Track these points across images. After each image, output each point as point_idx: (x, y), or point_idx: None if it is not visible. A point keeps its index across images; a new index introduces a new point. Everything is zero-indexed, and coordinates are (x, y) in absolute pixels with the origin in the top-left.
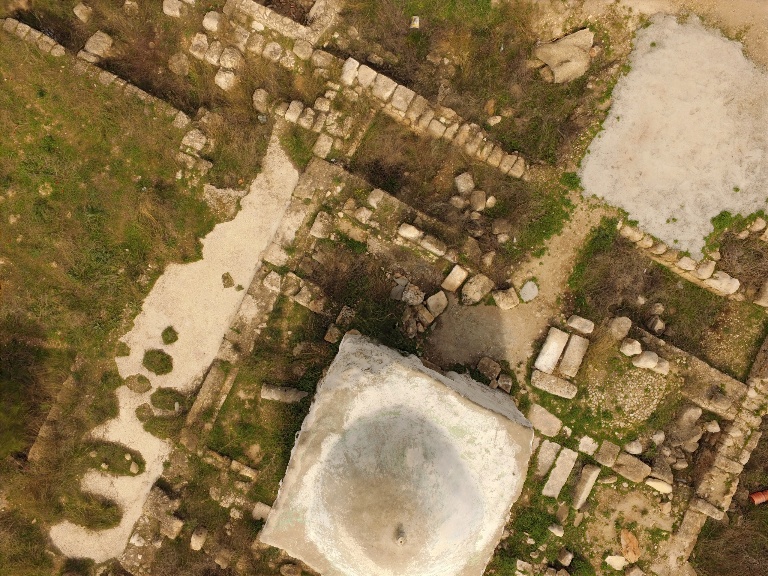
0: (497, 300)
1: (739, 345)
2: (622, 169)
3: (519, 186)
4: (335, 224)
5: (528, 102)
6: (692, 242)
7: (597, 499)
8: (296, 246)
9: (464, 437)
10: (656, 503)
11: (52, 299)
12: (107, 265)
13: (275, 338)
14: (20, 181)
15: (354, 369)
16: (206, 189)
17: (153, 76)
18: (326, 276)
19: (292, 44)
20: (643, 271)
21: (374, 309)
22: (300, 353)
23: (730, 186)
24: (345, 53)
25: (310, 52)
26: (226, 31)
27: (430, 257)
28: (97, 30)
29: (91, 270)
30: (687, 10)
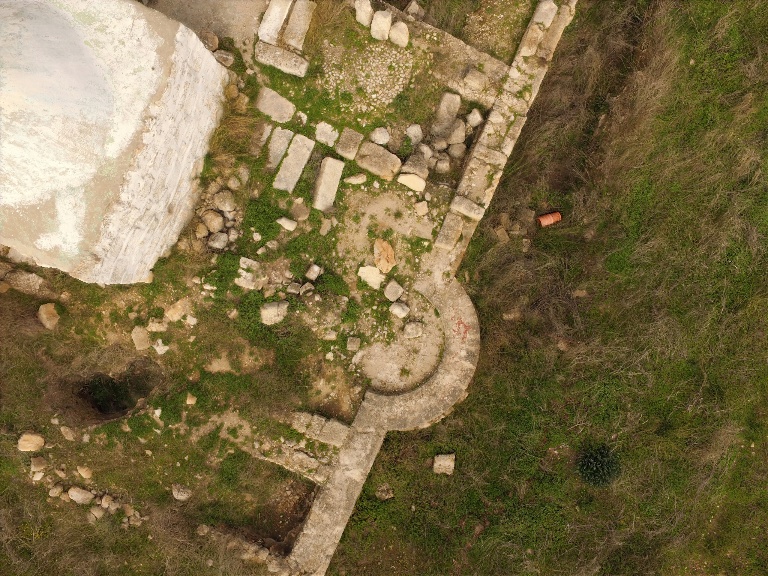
0: None
1: (504, 26)
2: None
3: None
4: None
5: None
6: None
7: (346, 204)
8: None
9: (92, 24)
10: (411, 204)
11: None
12: None
13: None
14: None
15: None
16: None
17: None
18: None
19: None
20: None
21: None
22: None
23: None
24: None
25: None
26: None
27: None
28: None
29: None
30: None
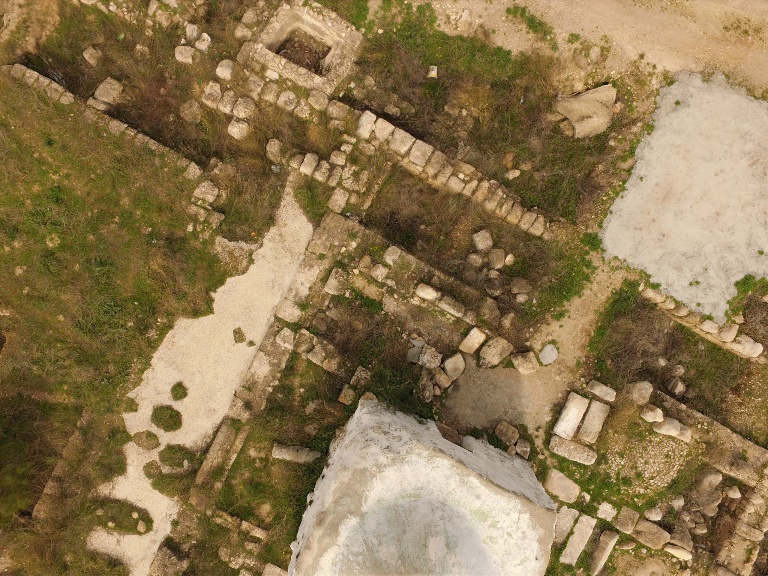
0: (516, 364)
1: (761, 409)
2: (645, 230)
3: (539, 245)
4: (350, 281)
5: (548, 156)
6: (715, 305)
7: (614, 564)
8: (310, 302)
9: (486, 521)
10: (675, 570)
11: (59, 353)
12: (115, 319)
13: (287, 396)
14: (27, 232)
15: (373, 447)
16: (218, 242)
17: (164, 123)
18: (340, 333)
19: (307, 94)
20: (664, 331)
21: (391, 376)
22: (313, 412)
23: (755, 249)
24: (361, 103)
25: (326, 103)
26: (240, 80)
27: (447, 318)
28: (107, 75)
29: (99, 324)
30: (713, 68)
